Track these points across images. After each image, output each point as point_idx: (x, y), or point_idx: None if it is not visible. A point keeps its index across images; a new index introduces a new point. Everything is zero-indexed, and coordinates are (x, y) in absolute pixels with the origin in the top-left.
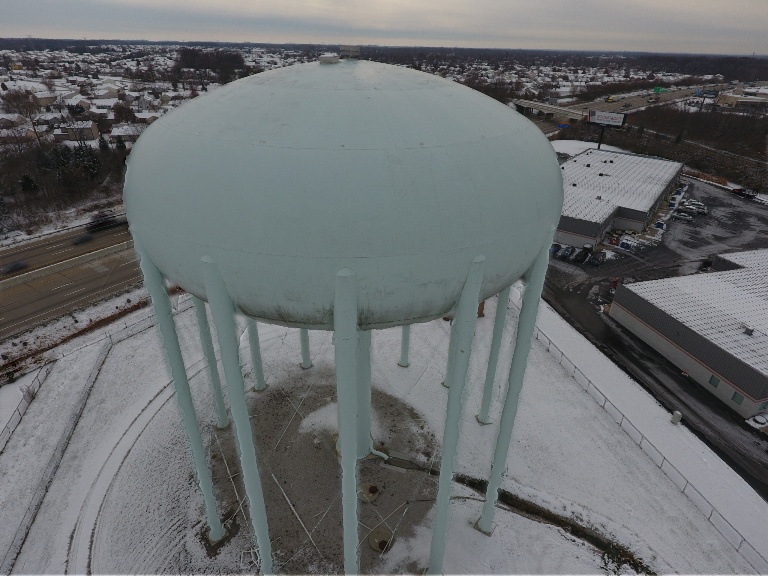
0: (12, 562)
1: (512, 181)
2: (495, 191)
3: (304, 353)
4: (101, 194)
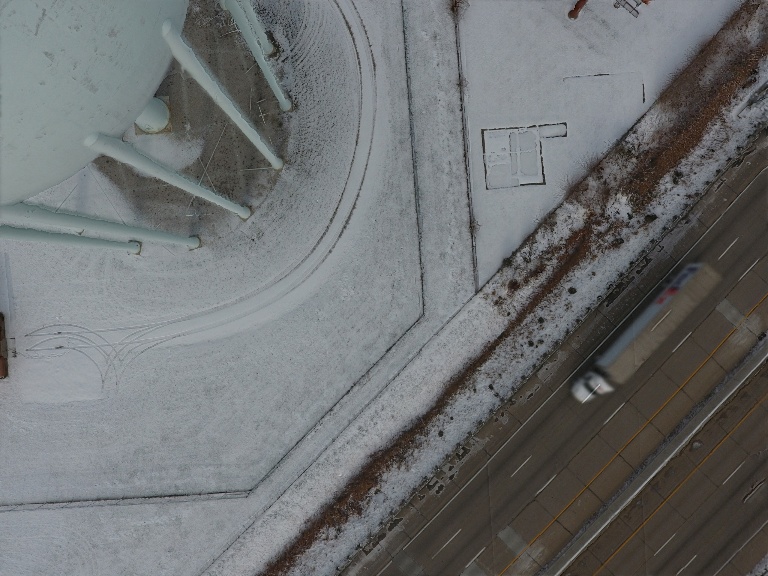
0: (407, 51)
1: None
2: None
3: None
4: None
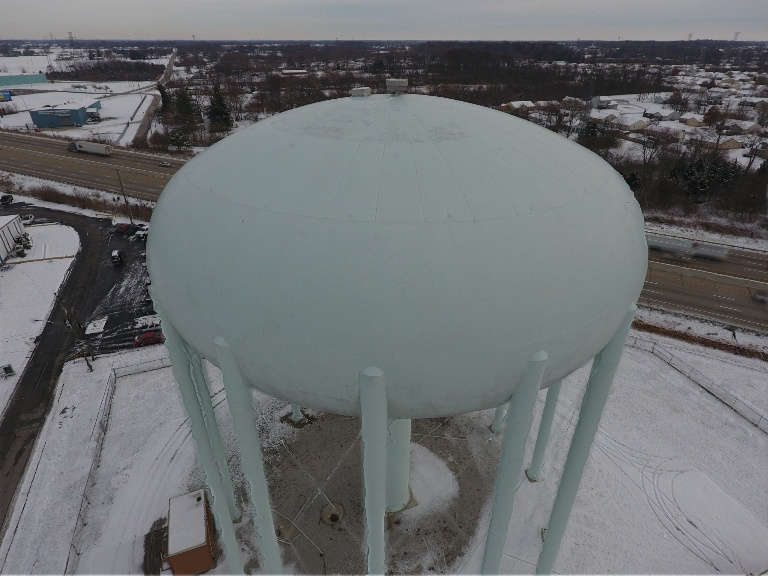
0: None
1: (181, 242)
2: (166, 239)
3: (496, 414)
4: (681, 211)
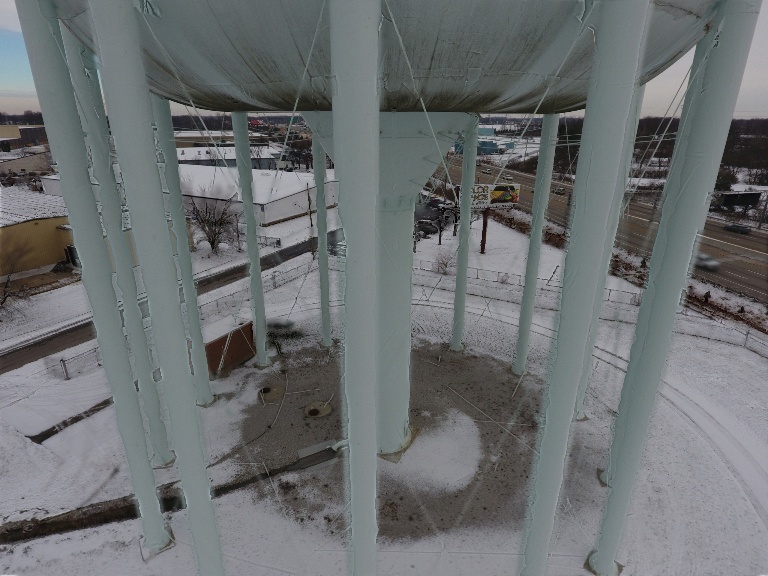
0: None
1: None
2: None
3: None
4: None
